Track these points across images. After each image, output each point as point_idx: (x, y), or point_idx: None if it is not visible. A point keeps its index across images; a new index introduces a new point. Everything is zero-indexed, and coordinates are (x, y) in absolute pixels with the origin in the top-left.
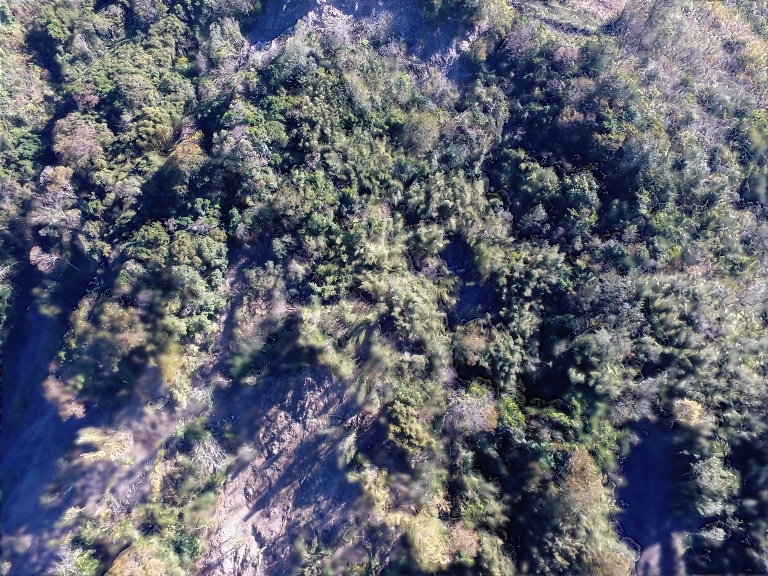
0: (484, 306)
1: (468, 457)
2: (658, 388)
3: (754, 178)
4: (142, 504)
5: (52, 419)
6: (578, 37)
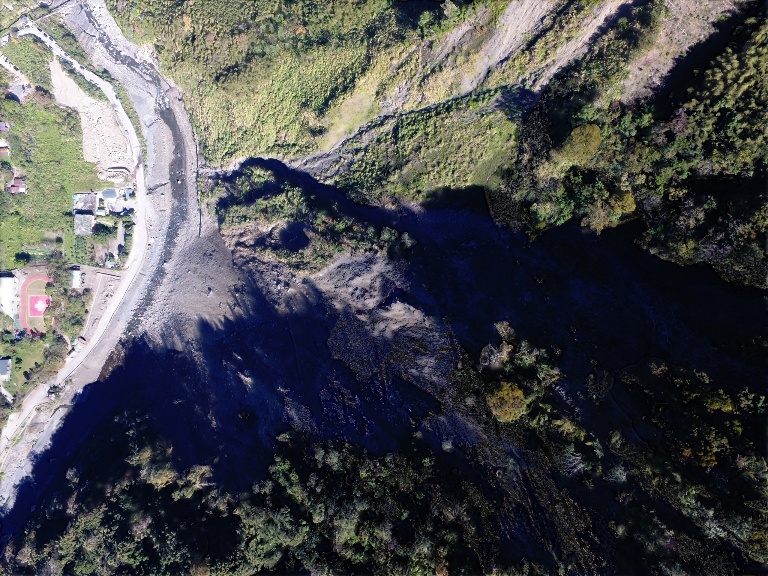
0: None
1: None
2: None
3: None
4: (549, 397)
5: (641, 314)
6: None
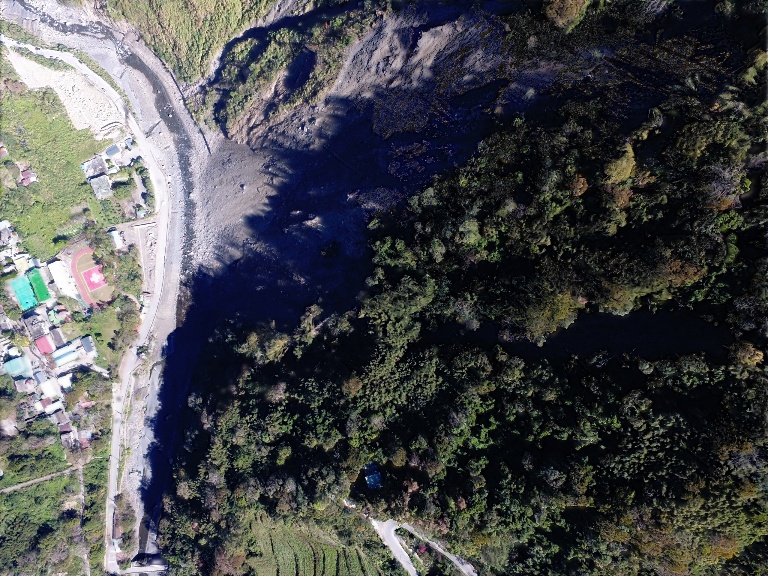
0: None
1: (676, 194)
2: (762, 330)
3: None
4: None
5: None
6: None
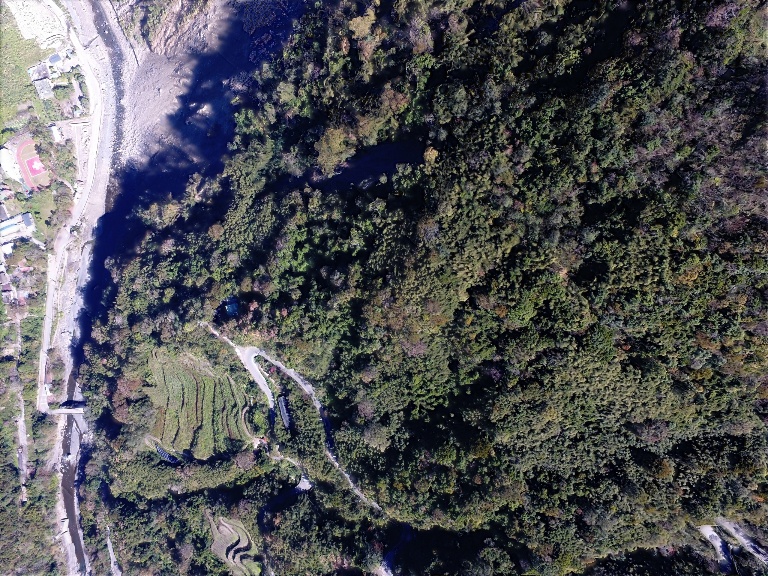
0: (483, 31)
1: (401, 47)
2: None
3: (605, 212)
4: None
5: None
6: (723, 14)
